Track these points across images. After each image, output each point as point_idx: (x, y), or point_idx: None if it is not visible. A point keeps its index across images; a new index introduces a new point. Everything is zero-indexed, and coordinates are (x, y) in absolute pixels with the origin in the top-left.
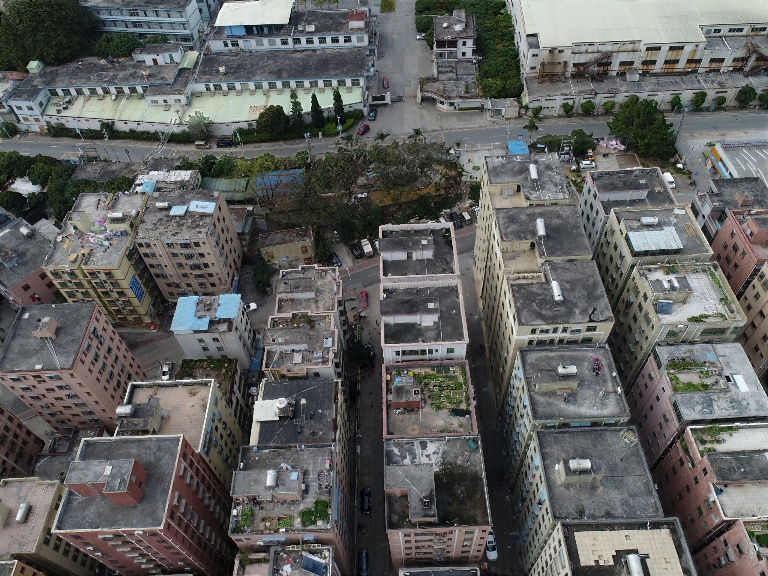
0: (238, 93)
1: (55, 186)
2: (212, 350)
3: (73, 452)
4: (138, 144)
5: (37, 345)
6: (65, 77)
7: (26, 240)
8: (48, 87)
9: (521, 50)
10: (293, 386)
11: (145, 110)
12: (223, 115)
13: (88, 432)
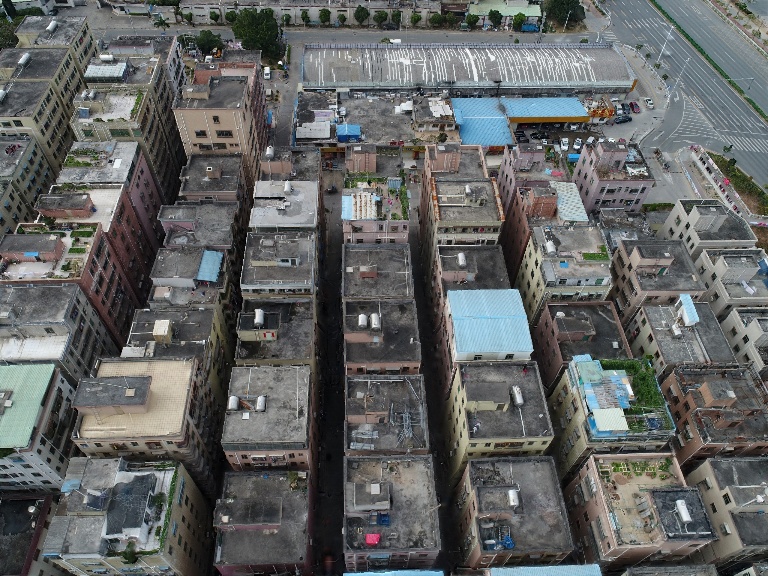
0: None
1: None
2: None
3: None
4: None
5: None
6: None
7: None
8: None
9: None
10: None
11: None
12: None
13: None
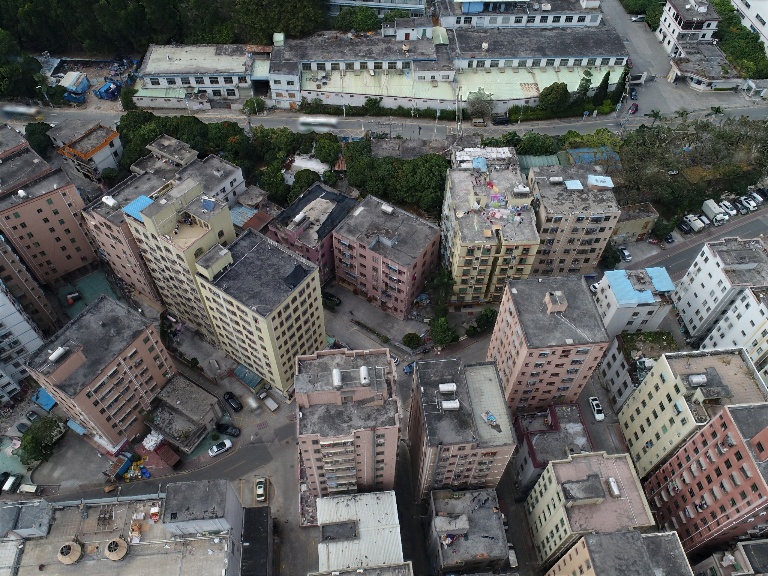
0: (502, 70)
1: (365, 163)
2: (635, 324)
3: (561, 429)
4: (407, 121)
5: (550, 320)
6: (316, 51)
7: (389, 218)
8: (304, 61)
9: (766, 33)
10: None
11: (412, 86)
12: (497, 92)
13: (564, 408)
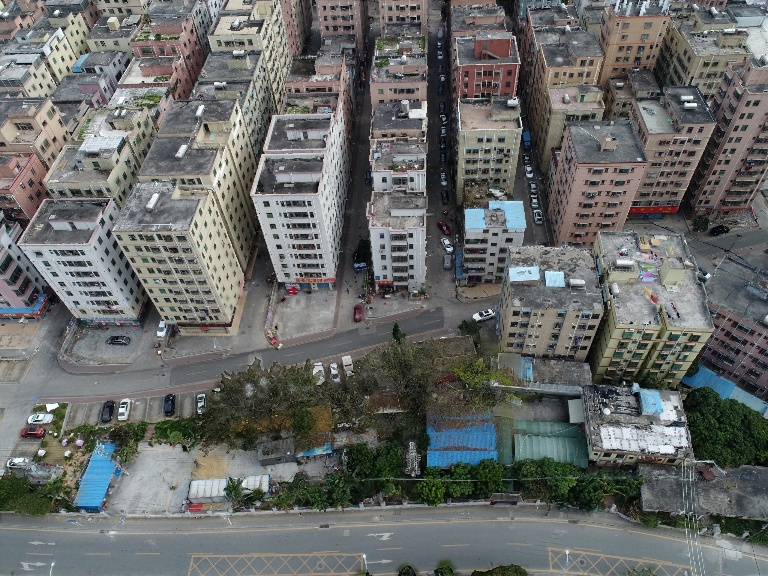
0: None
1: None
2: None
3: None
4: None
5: None
6: None
7: None
8: None
9: None
10: (401, 125)
11: None
12: None
13: None
